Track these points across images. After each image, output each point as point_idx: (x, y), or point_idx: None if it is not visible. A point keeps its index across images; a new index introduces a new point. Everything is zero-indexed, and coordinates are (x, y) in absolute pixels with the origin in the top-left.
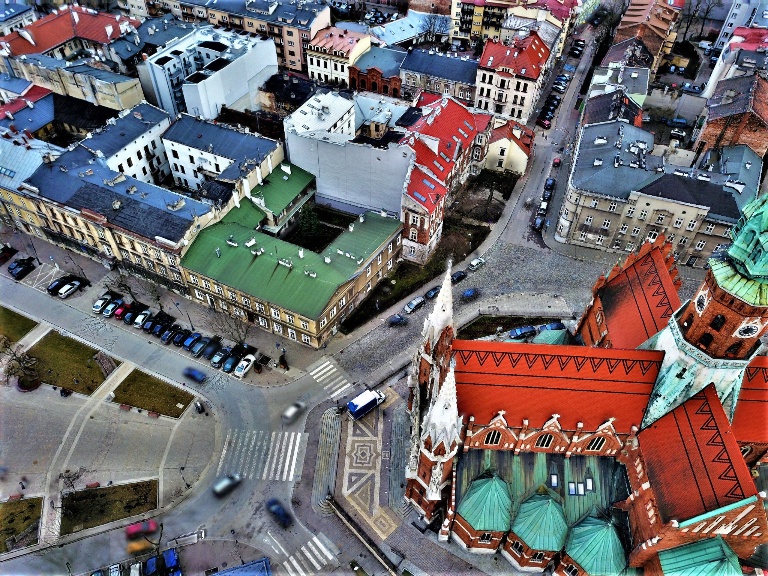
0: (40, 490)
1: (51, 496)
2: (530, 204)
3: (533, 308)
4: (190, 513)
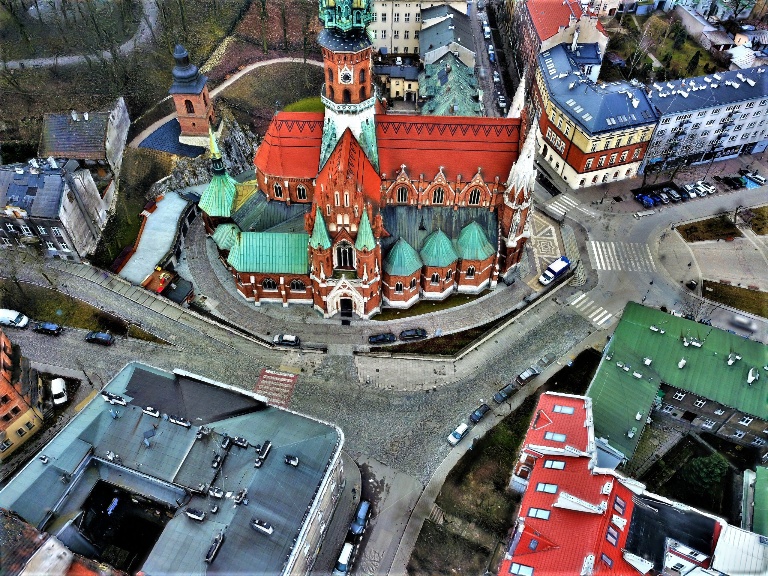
0: (764, 239)
1: (753, 236)
2: (364, 575)
3: (396, 370)
4: (651, 225)
